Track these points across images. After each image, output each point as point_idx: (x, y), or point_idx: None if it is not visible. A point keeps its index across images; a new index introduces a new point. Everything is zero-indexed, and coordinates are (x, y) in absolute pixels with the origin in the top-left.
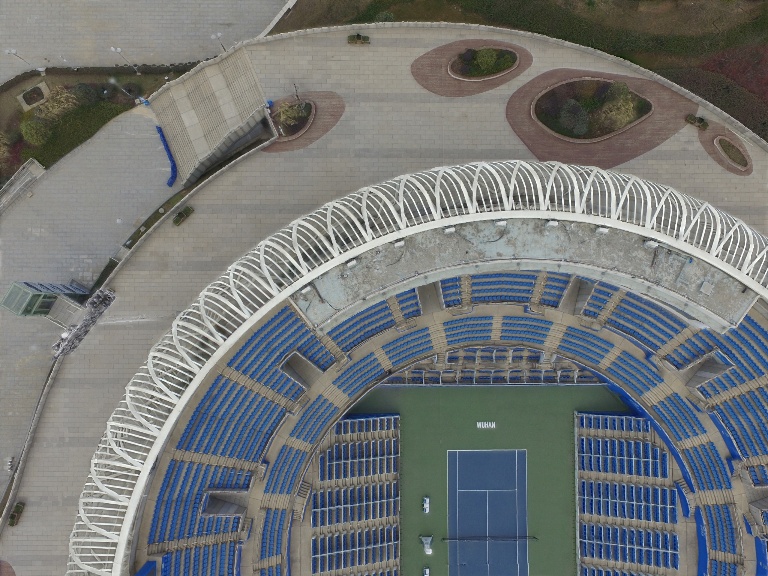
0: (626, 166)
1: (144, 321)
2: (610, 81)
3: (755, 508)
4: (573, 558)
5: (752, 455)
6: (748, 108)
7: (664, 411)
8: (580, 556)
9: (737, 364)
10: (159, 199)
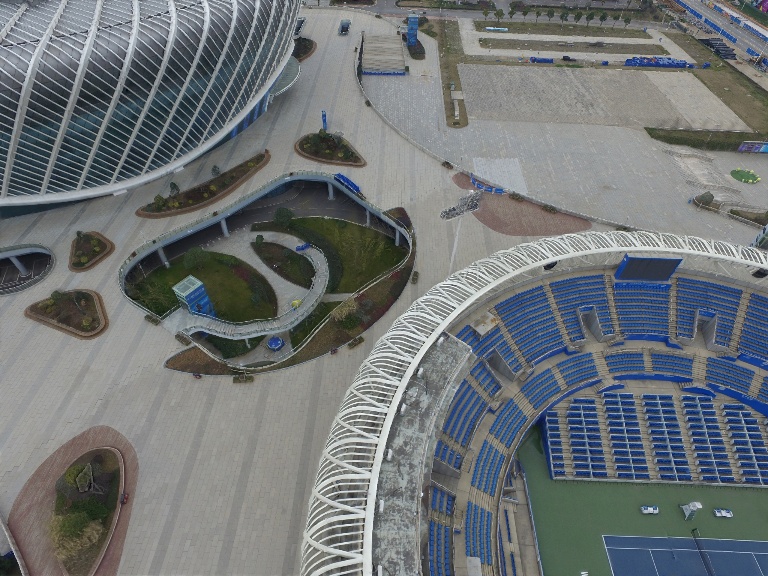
0: None
1: None
2: None
3: None
4: None
5: None
6: None
7: None
8: None
9: None
10: None
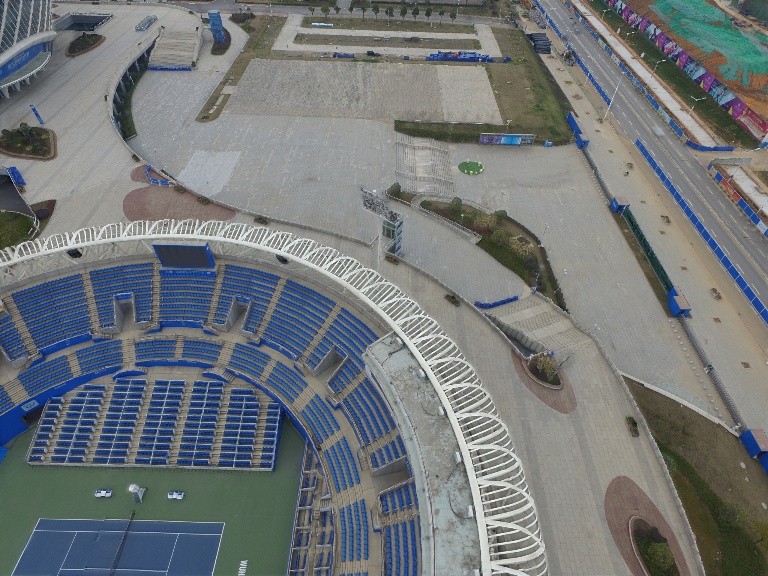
0: None
1: None
2: None
3: None
4: None
5: None
6: None
7: None
8: None
9: None
10: None
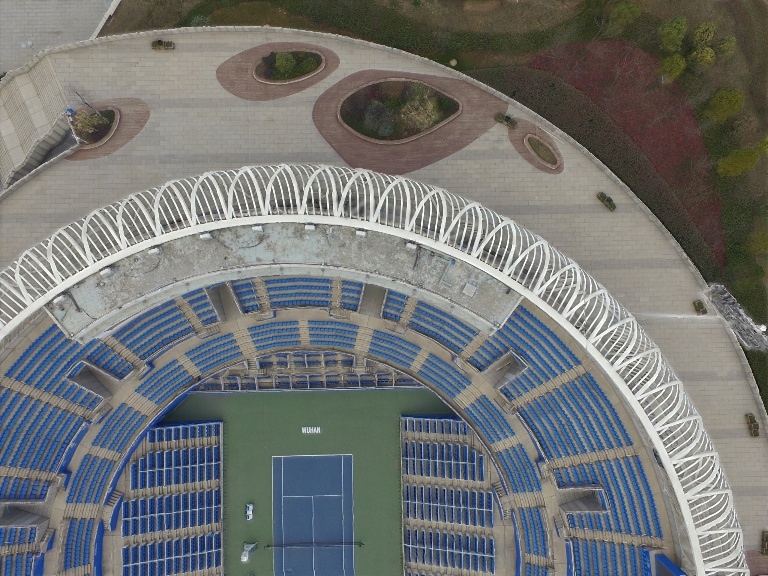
0: (435, 167)
1: None
2: (417, 81)
3: (562, 511)
4: (400, 563)
5: (556, 457)
6: (575, 105)
7: (476, 413)
8: (404, 561)
9: (533, 365)
10: None
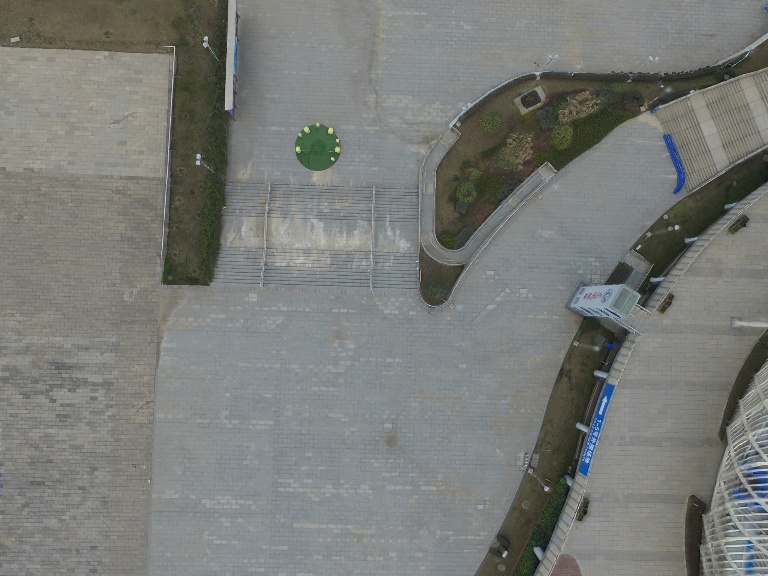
0: None
1: (700, 326)
2: None
3: None
4: None
5: None
6: None
7: None
8: None
9: None
10: (664, 205)
